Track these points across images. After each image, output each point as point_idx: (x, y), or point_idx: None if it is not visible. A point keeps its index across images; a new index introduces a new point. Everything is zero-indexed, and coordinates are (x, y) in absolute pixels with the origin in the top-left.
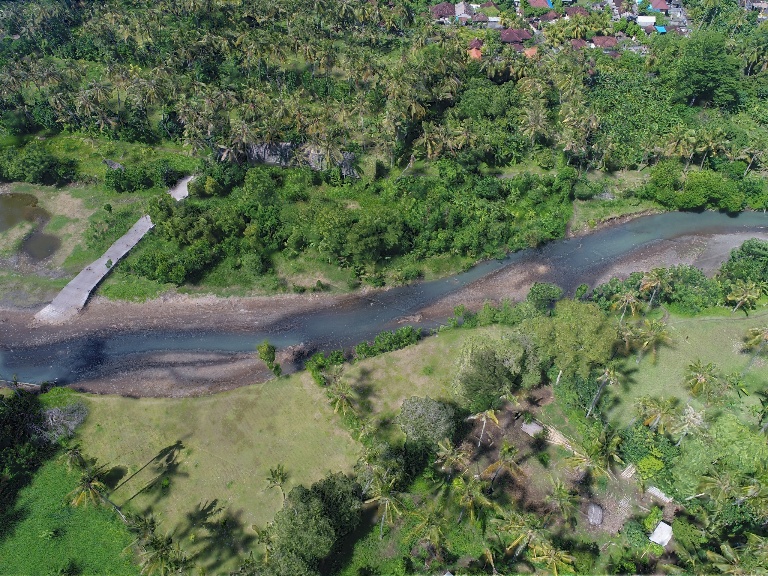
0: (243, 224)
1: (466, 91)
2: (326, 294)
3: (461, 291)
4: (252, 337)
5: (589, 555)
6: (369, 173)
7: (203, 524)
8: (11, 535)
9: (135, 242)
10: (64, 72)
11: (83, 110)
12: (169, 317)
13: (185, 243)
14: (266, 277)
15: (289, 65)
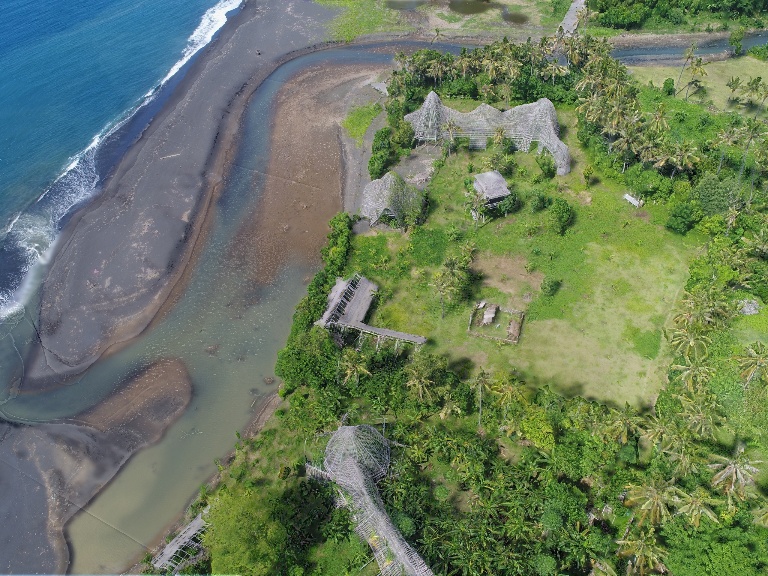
0: None
1: None
2: (727, 32)
3: None
4: None
5: None
6: None
7: (739, 104)
8: None
9: None
10: None
11: None
12: (633, 43)
13: None
14: (683, 25)
15: None
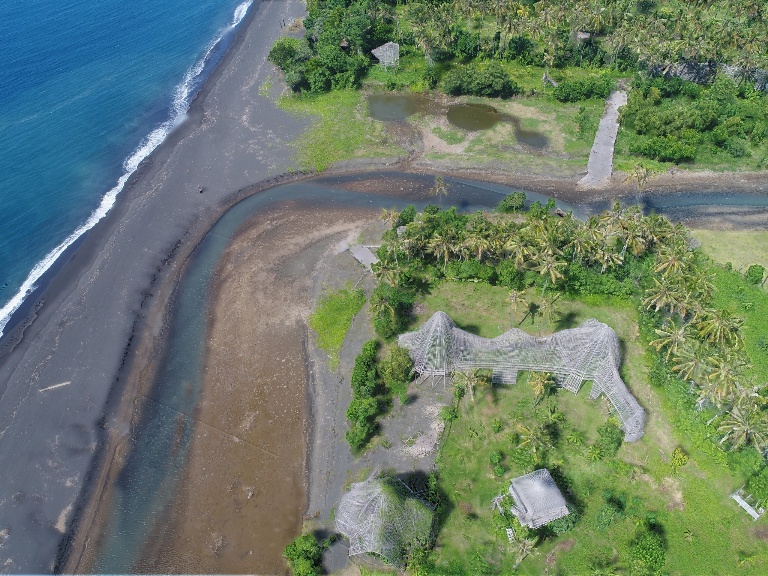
0: (717, 118)
1: None
2: None
3: None
4: (766, 197)
5: None
6: None
7: None
8: None
9: (615, 135)
10: (507, 4)
11: (534, 34)
12: (687, 184)
13: (660, 135)
14: (745, 158)
15: None
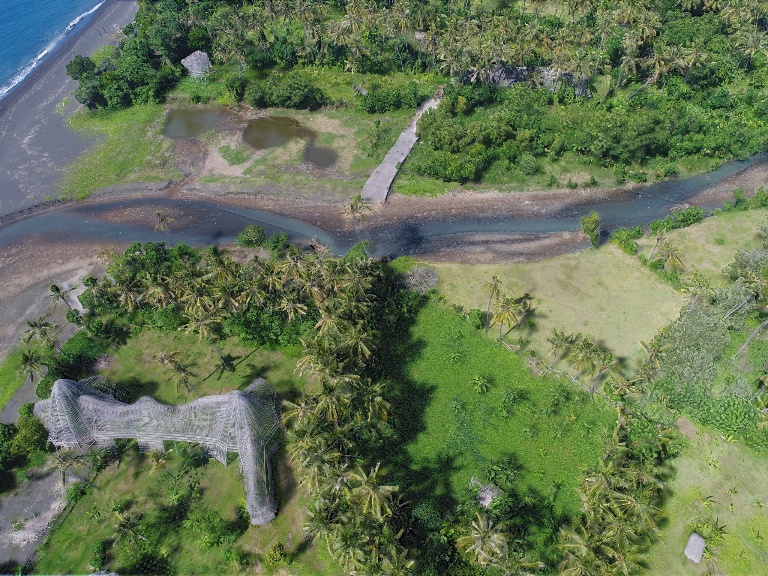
0: (512, 131)
1: (670, 22)
2: (596, 189)
3: (717, 185)
4: (545, 222)
5: None
6: (602, 91)
7: None
8: (420, 358)
9: (408, 151)
10: (315, 7)
11: (338, 40)
12: (464, 208)
13: (455, 150)
14: (538, 176)
15: (476, 8)
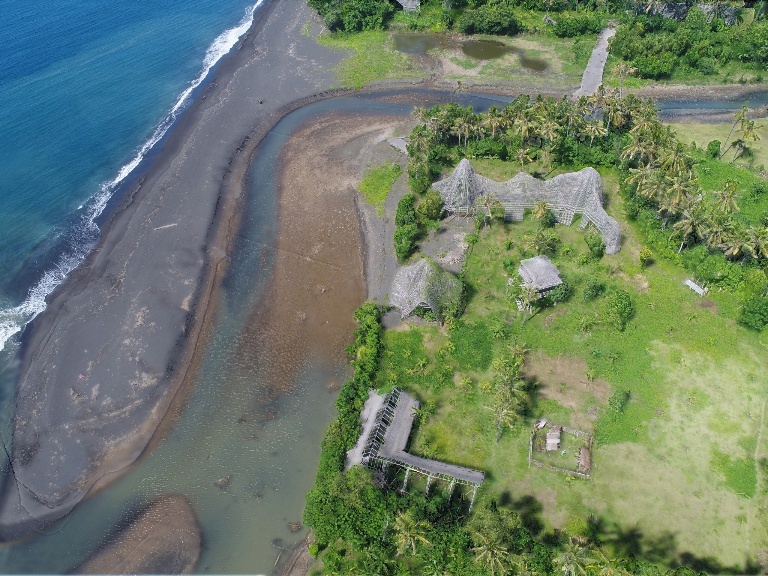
0: (690, 43)
1: None
2: (761, 84)
3: None
4: (730, 103)
5: None
6: (748, 21)
7: None
8: None
9: (605, 60)
10: None
11: None
12: (664, 95)
13: None
14: (714, 76)
15: None
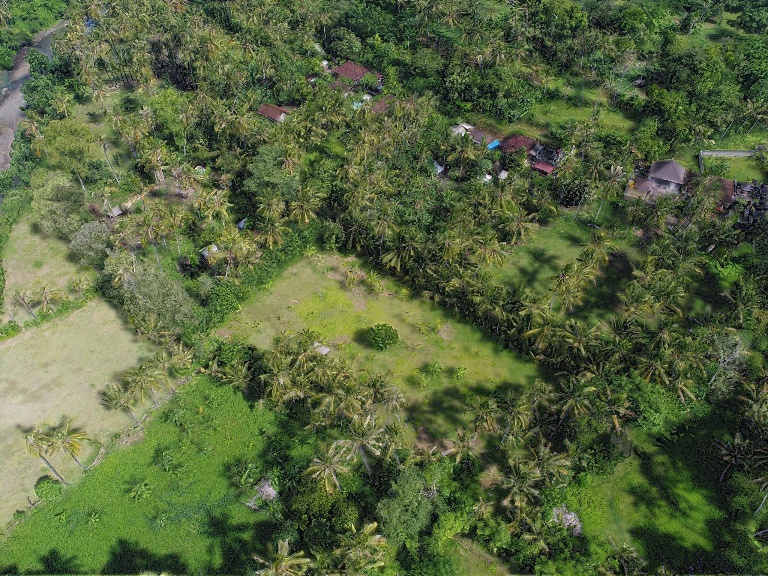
0: None
1: None
2: None
3: None
4: None
5: (205, 188)
6: None
7: None
8: (80, 566)
9: None
10: None
11: None
12: None
13: None
14: None
15: None
